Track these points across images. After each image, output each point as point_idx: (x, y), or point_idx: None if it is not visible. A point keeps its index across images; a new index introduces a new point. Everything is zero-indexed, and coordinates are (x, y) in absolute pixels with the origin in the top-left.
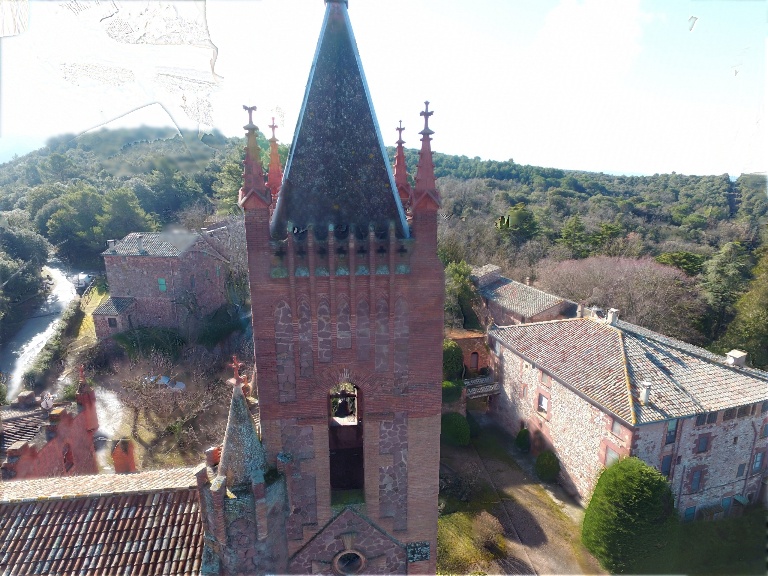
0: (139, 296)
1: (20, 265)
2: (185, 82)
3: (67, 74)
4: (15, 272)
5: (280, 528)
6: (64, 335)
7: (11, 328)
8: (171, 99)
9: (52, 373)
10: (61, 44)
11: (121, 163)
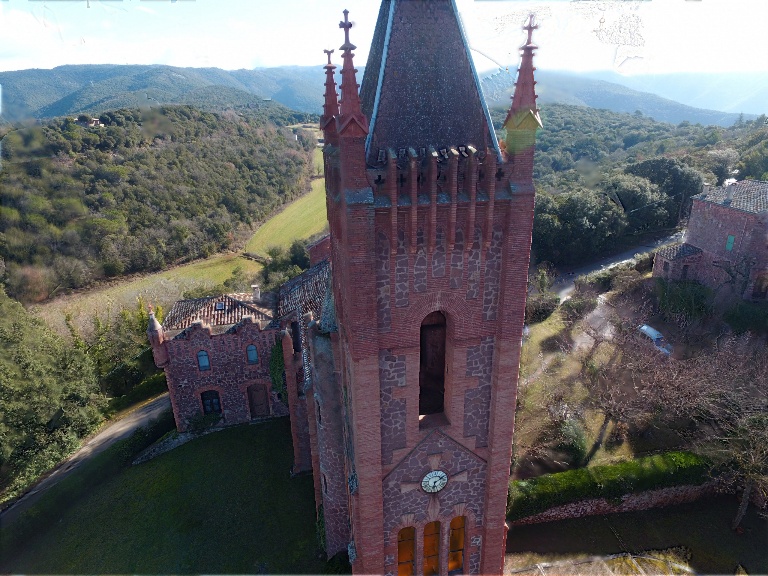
0: (706, 249)
1: (661, 198)
2: (602, 1)
3: (499, 26)
4: (651, 203)
5: (328, 374)
6: (639, 265)
7: (623, 248)
8: (584, 25)
9: (601, 289)
10: (500, 1)
11: (486, 99)
